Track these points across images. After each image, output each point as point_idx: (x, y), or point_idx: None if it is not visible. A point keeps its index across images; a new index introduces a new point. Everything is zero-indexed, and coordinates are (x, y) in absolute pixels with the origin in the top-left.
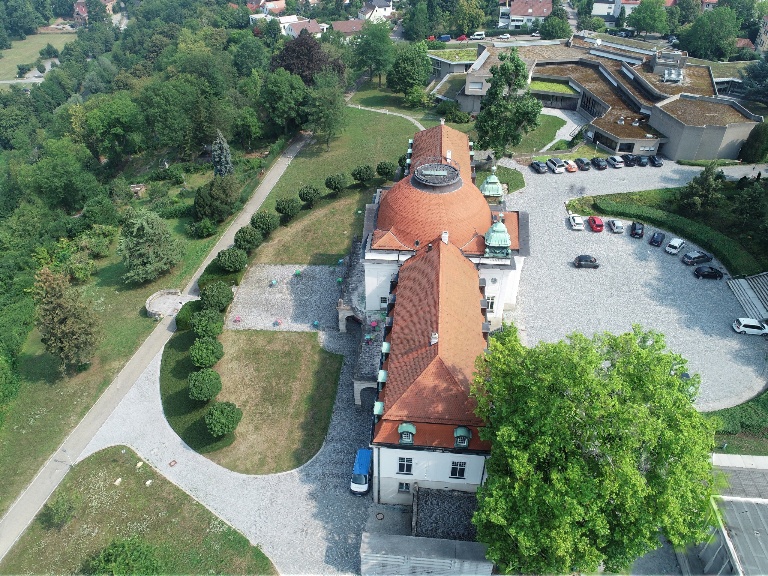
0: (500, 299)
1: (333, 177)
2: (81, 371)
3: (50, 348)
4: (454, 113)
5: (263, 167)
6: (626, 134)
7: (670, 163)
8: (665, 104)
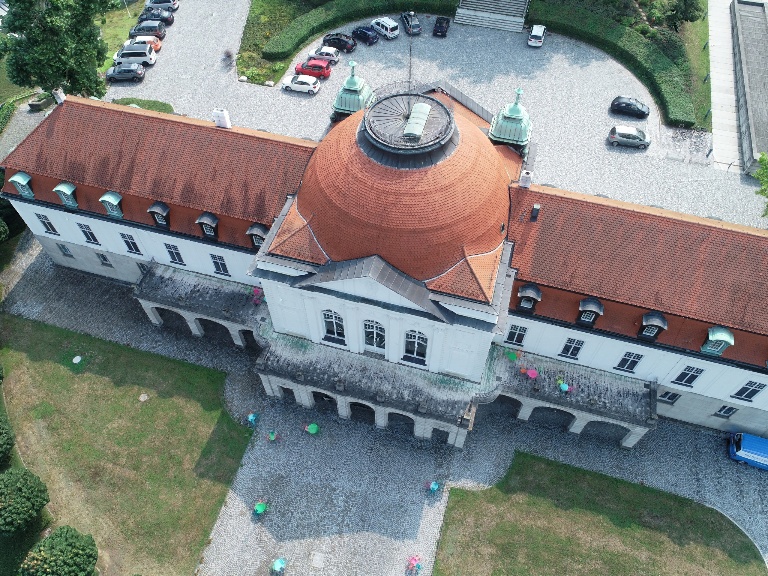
0: None
1: None
2: None
3: None
4: None
5: None
6: None
7: None
8: None
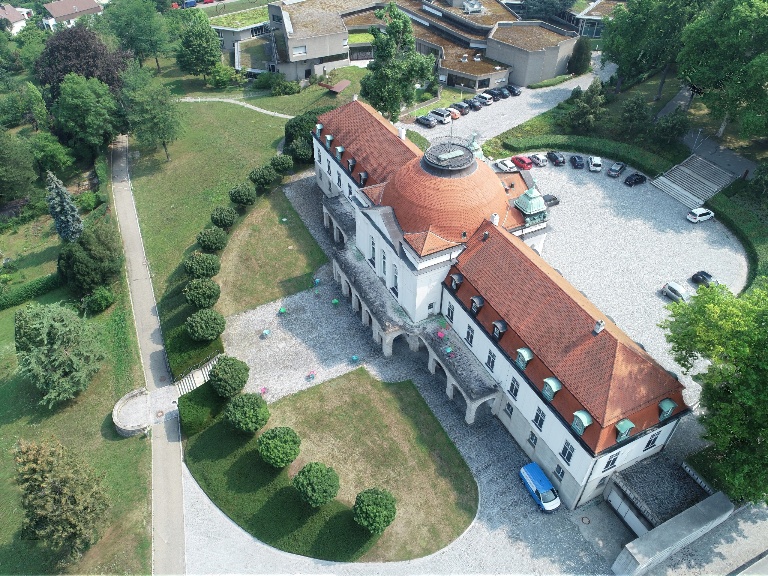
0: None
1: (240, 190)
2: (88, 547)
3: (54, 542)
4: (282, 85)
5: (106, 201)
6: (478, 71)
7: (523, 89)
8: (493, 35)
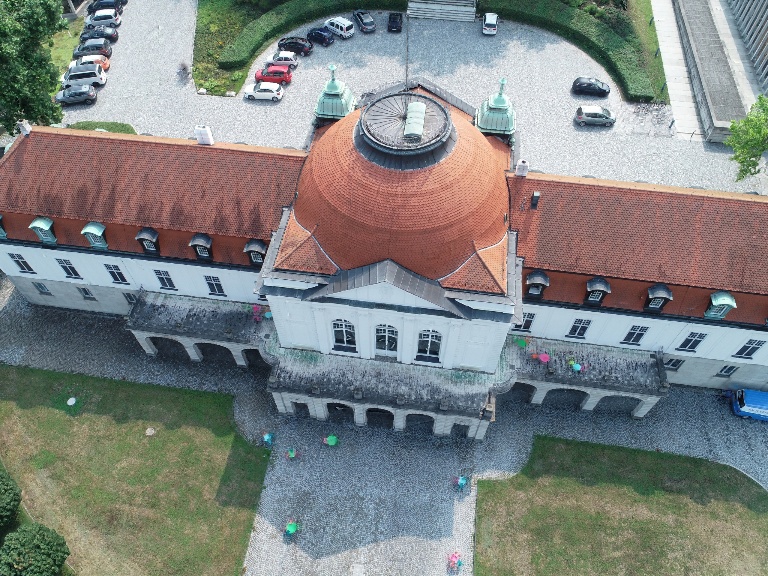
0: None
1: None
2: None
3: None
4: None
5: None
6: None
7: None
8: None
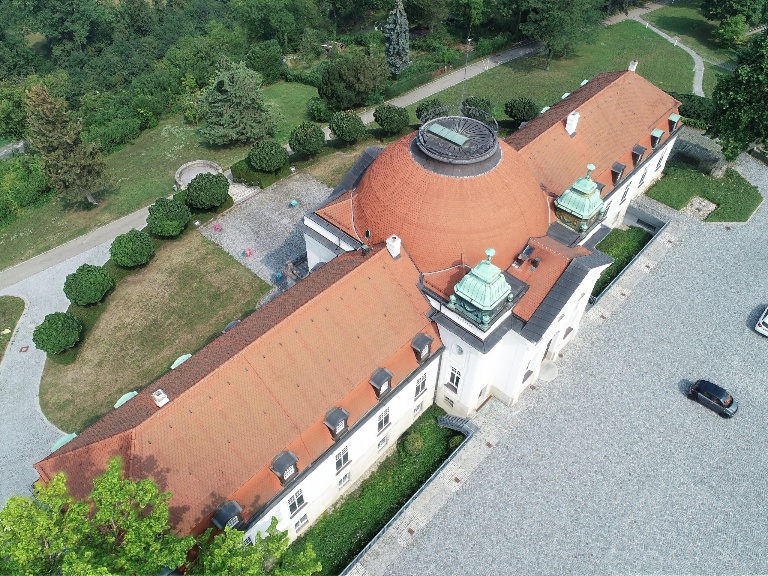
0: (466, 381)
1: (472, 100)
2: (85, 209)
3: None
4: None
5: (450, 63)
6: None
7: None
8: None
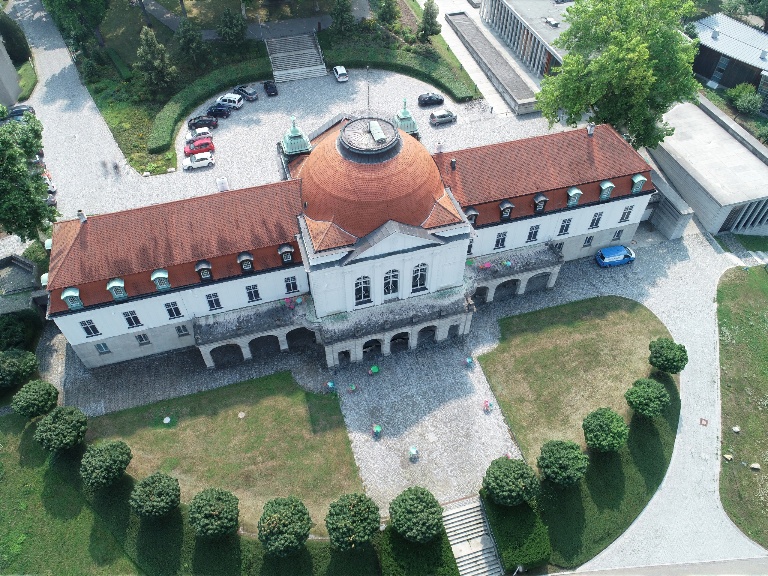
0: None
1: (109, 458)
2: None
3: None
4: None
5: None
6: None
7: None
8: None
